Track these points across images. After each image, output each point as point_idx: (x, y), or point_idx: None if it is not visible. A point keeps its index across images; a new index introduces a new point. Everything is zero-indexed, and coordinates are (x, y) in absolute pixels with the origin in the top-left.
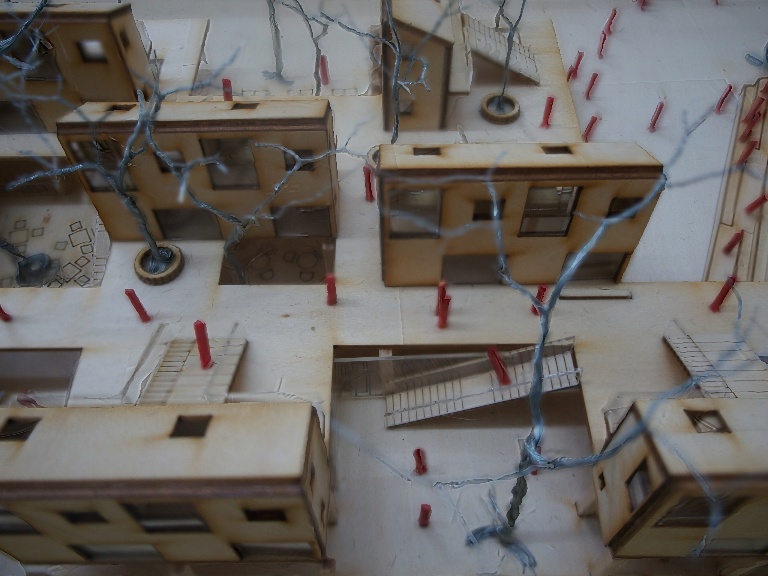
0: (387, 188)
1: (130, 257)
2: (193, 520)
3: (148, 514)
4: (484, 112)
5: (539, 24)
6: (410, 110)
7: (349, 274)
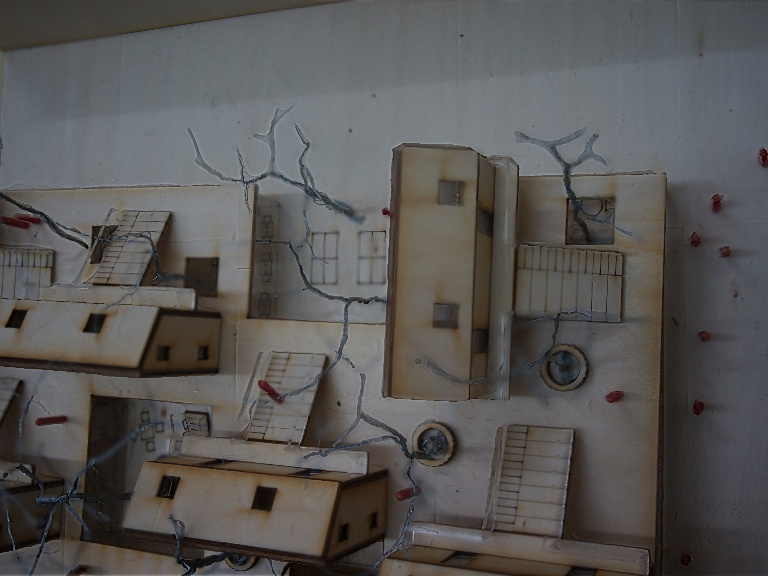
0: None
1: None
2: None
3: None
4: None
5: (646, 188)
6: None
7: None
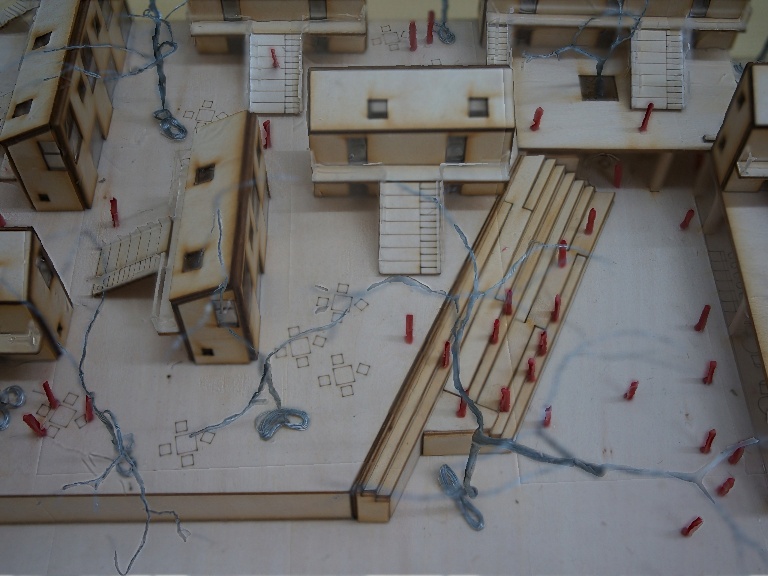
0: None
1: None
2: None
3: None
4: None
5: None
6: None
7: None
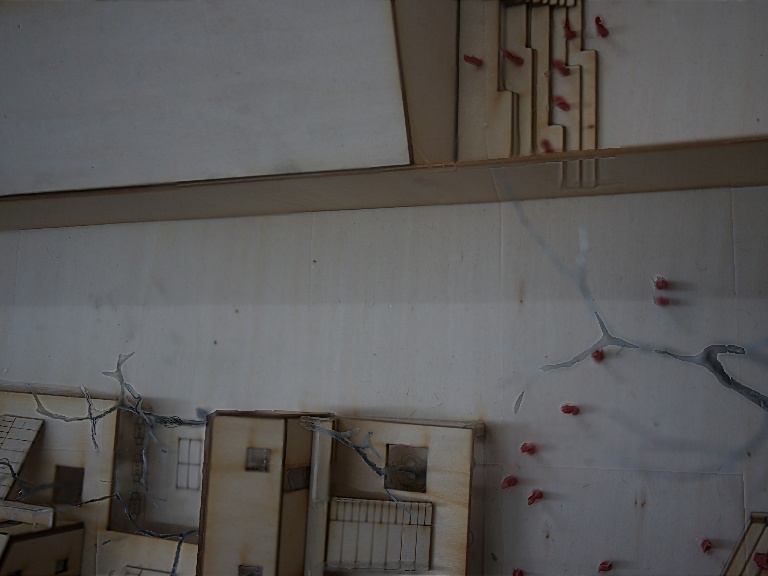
0: None
1: None
2: None
3: None
4: None
5: (454, 442)
6: None
7: None
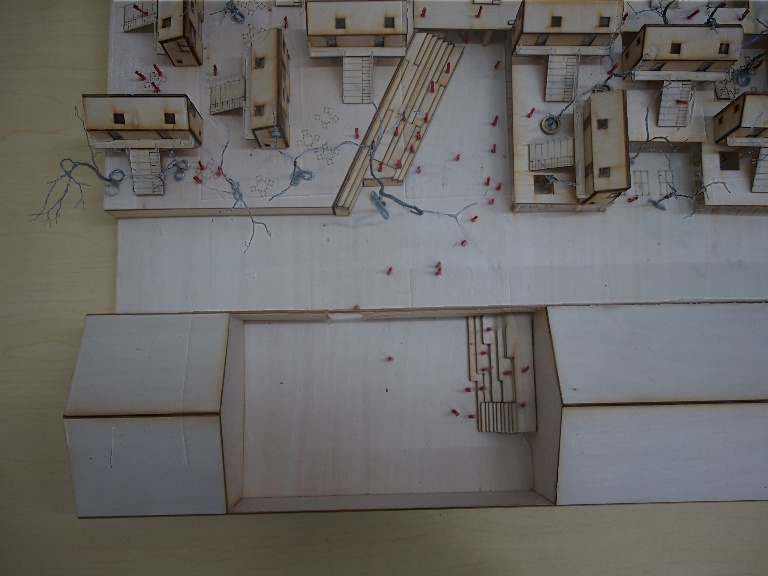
0: None
1: None
2: None
3: None
4: None
5: (522, 197)
6: None
7: None
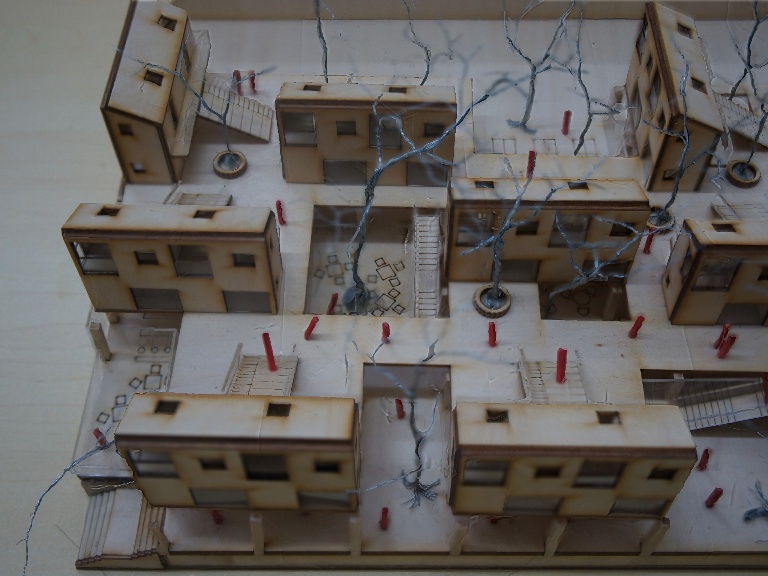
0: (704, 258)
1: (467, 295)
2: (612, 476)
3: (587, 471)
4: (731, 177)
5: (765, 91)
6: (674, 177)
7: (642, 314)
